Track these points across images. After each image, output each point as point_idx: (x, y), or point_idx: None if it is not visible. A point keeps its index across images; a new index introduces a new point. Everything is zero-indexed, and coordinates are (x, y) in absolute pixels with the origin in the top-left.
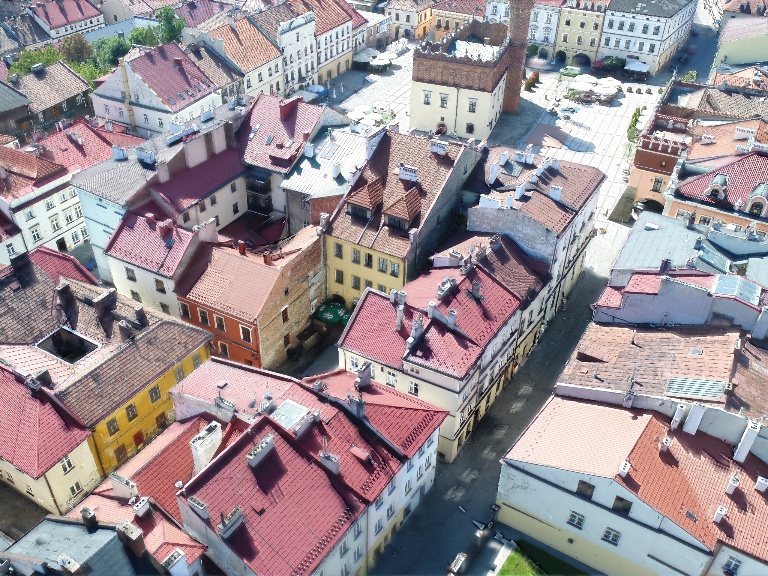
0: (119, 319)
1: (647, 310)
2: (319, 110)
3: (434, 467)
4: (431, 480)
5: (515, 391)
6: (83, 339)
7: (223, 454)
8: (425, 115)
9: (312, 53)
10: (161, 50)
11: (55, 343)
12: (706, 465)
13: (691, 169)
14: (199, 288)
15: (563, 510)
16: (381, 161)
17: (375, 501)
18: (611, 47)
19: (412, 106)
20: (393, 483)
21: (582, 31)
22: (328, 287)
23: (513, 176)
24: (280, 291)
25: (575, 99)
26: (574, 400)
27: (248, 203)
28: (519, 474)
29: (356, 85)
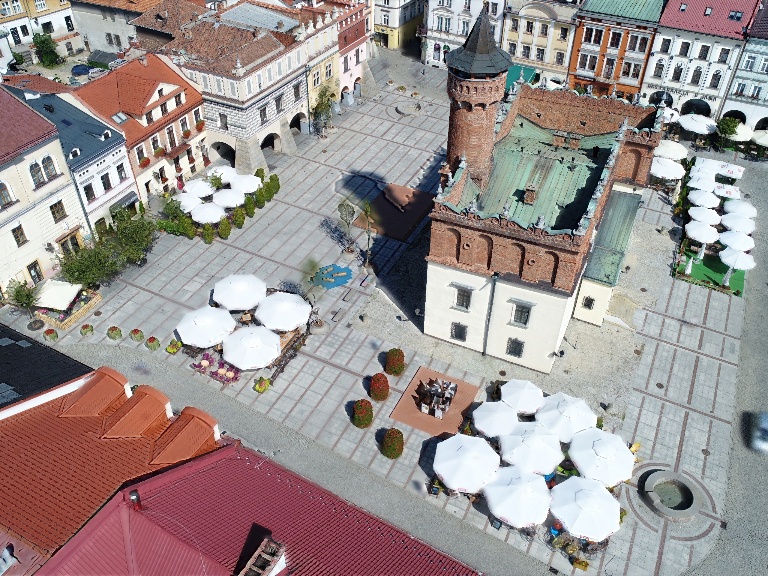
0: None
1: None
2: None
3: None
4: None
5: None
6: None
7: None
8: None
9: None
10: None
11: None
12: None
13: None
14: None
15: None
16: None
17: None
18: None
19: None
20: None
21: None
22: None
23: None
24: None
25: None
26: None
27: None
28: None
29: None
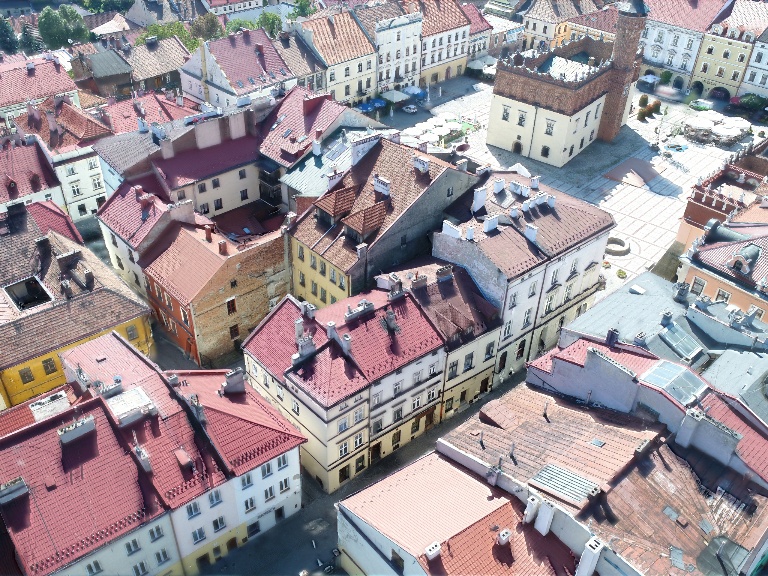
0: (75, 278)
1: (574, 382)
2: (340, 109)
3: (298, 492)
4: (296, 505)
5: (437, 437)
6: (44, 290)
7: (39, 423)
8: (502, 131)
9: (415, 54)
10: (246, 35)
11: (31, 289)
12: (542, 574)
13: (722, 233)
14: (157, 264)
15: (384, 575)
16: (365, 169)
17: (178, 509)
18: (756, 83)
19: (490, 120)
20: (220, 496)
21: (725, 62)
22: (295, 287)
23: (502, 207)
24: (224, 281)
25: (689, 136)
26: (449, 461)
27: (260, 192)
28: (350, 524)
29: (459, 92)
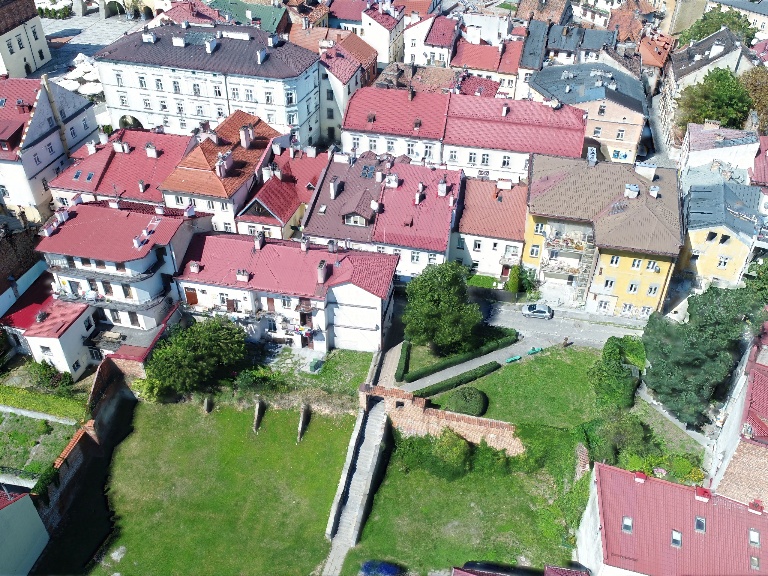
0: None
1: None
2: None
3: None
4: None
5: None
6: None
7: None
8: (15, 65)
9: None
10: None
11: None
12: None
13: None
14: None
15: None
16: None
17: None
18: None
19: (5, 63)
20: None
21: None
22: None
23: None
24: None
25: None
26: None
27: None
28: None
29: None
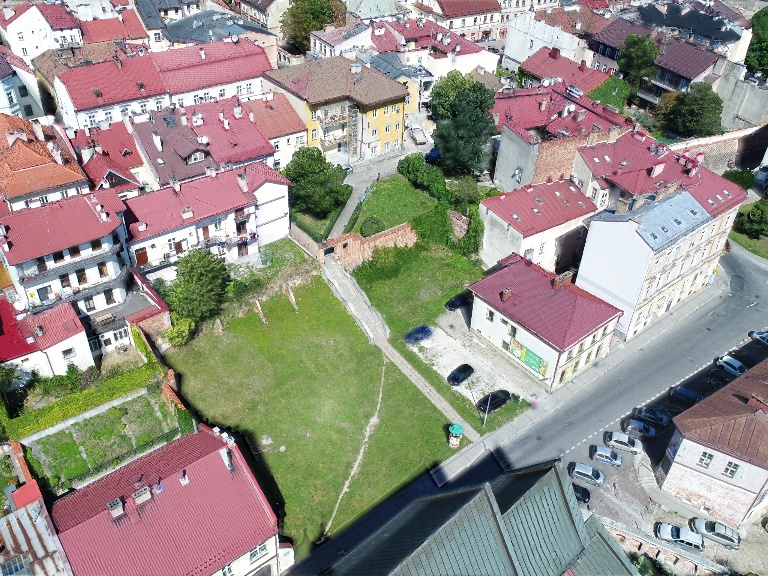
0: None
1: None
2: None
3: None
4: None
5: None
6: None
7: None
8: None
9: None
10: None
11: None
12: None
13: None
14: None
15: None
16: None
17: None
18: None
19: None
20: None
21: None
22: None
23: None
24: None
25: None
26: None
27: None
28: None
29: None
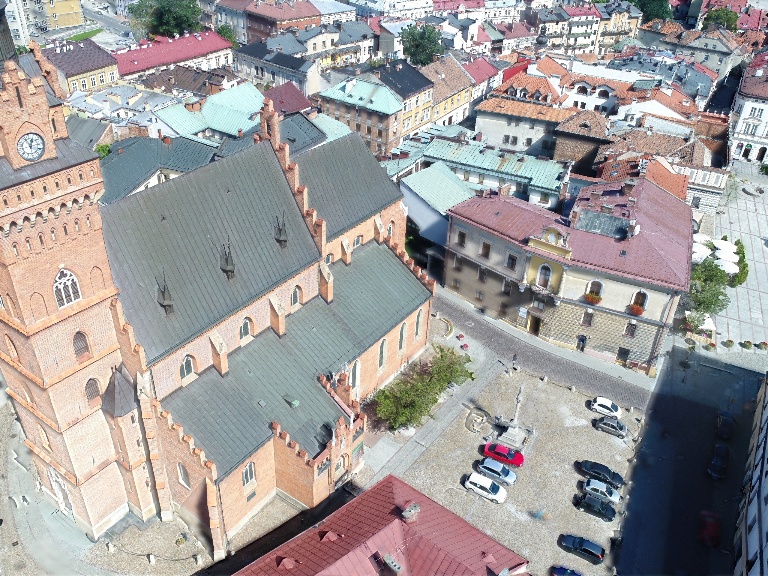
0: None
1: None
2: None
3: None
4: None
5: None
6: None
7: None
8: None
9: None
10: None
11: None
12: None
13: None
14: None
15: None
16: None
17: None
18: None
19: None
20: None
21: None
22: None
23: None
24: None
25: None
26: None
27: None
28: None
29: None
